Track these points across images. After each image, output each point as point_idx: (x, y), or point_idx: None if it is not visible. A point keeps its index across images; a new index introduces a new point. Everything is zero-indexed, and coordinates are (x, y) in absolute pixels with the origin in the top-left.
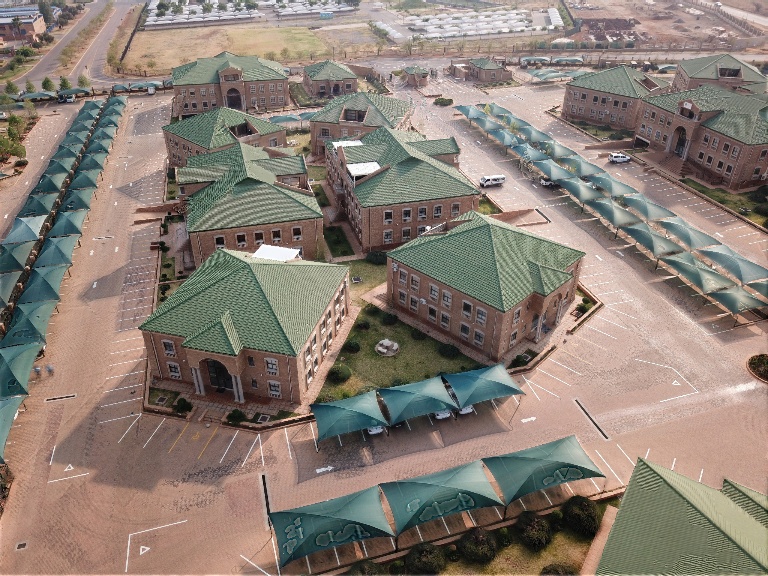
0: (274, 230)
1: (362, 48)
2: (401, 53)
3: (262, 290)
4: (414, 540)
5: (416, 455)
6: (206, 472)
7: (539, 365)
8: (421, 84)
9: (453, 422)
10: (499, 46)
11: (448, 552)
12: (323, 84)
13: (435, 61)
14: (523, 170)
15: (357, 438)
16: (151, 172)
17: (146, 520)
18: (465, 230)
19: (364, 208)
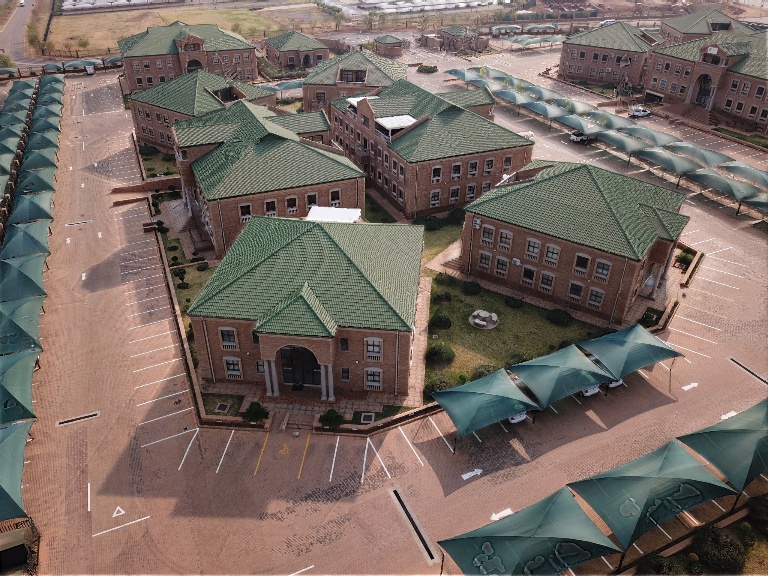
0: (309, 194)
1: (319, 23)
2: (360, 28)
3: (345, 253)
4: (631, 553)
5: (579, 443)
6: (316, 495)
7: (670, 324)
8: (396, 54)
9: (604, 398)
10: (463, 18)
11: (686, 564)
12: (292, 55)
13: (400, 34)
14: (623, 98)
15: (496, 430)
16: (116, 150)
17: (255, 573)
18: (558, 173)
19: (411, 164)
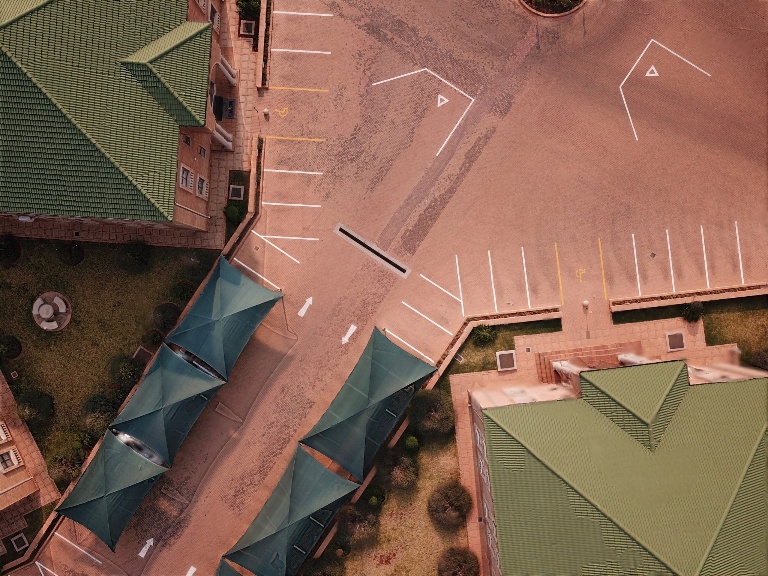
0: None
1: None
2: None
3: None
4: (297, 558)
5: (222, 456)
6: None
7: (262, 195)
8: None
9: None
10: None
11: None
12: None
13: None
14: None
15: None
16: None
17: None
18: None
19: None
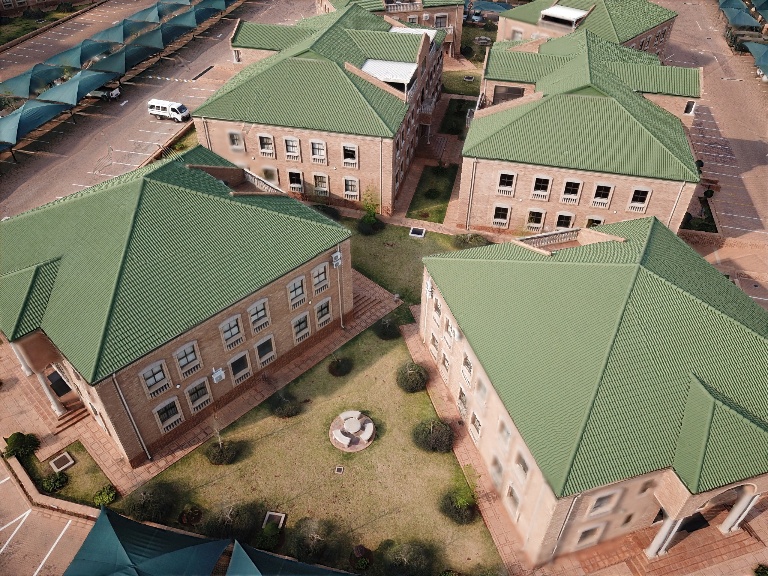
0: None
1: None
2: None
3: None
4: None
5: None
6: None
7: None
8: None
9: None
10: None
11: None
12: None
13: None
14: None
15: None
16: None
17: None
18: None
19: None
